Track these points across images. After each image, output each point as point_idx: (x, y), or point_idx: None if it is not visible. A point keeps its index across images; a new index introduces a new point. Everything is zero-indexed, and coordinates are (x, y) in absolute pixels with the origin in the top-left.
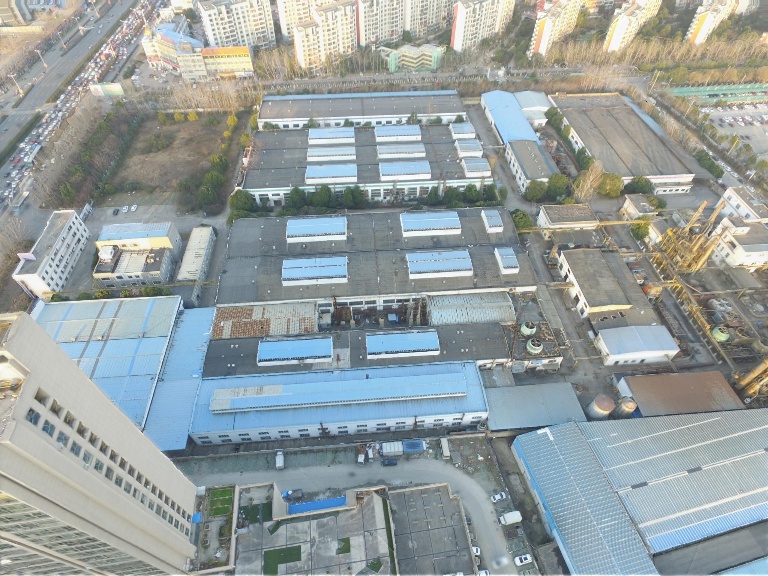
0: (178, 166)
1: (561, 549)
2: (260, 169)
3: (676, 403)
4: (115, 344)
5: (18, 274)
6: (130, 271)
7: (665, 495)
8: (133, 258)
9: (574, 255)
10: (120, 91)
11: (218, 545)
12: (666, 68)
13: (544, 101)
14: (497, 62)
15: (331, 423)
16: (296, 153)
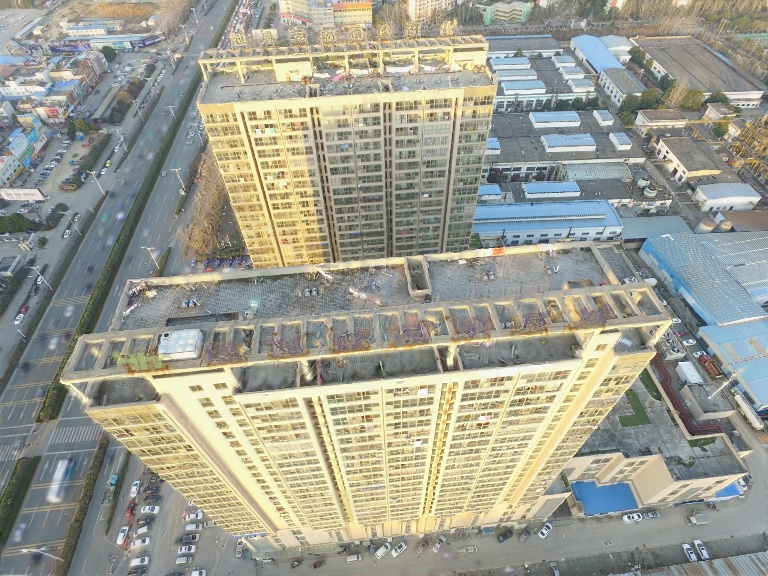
0: None
1: (687, 298)
2: None
3: (762, 225)
4: None
5: None
6: None
7: (759, 270)
8: None
9: (671, 141)
10: (275, 35)
11: None
12: (730, 18)
13: (626, 43)
14: (577, 16)
15: (511, 231)
16: None
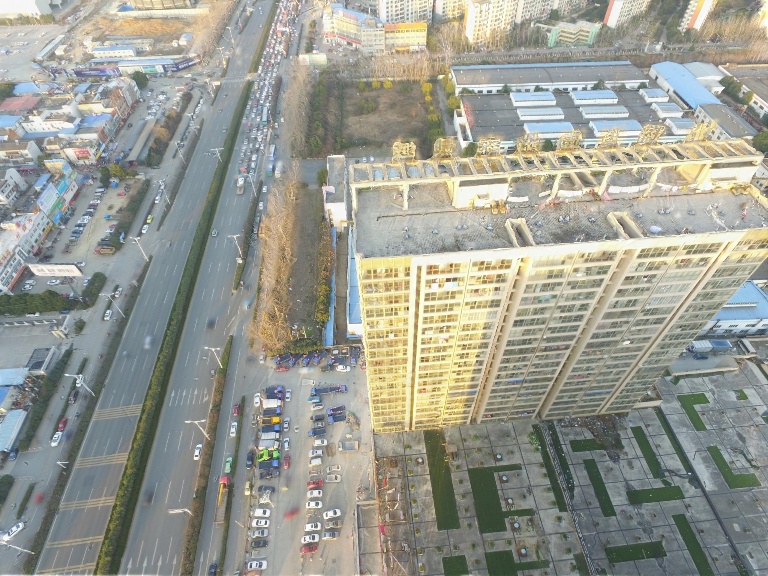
0: (392, 126)
1: None
2: (480, 126)
3: None
4: None
5: (329, 203)
6: None
7: None
8: None
9: None
10: (324, 61)
11: None
12: None
13: (715, 71)
14: None
15: None
16: (506, 113)
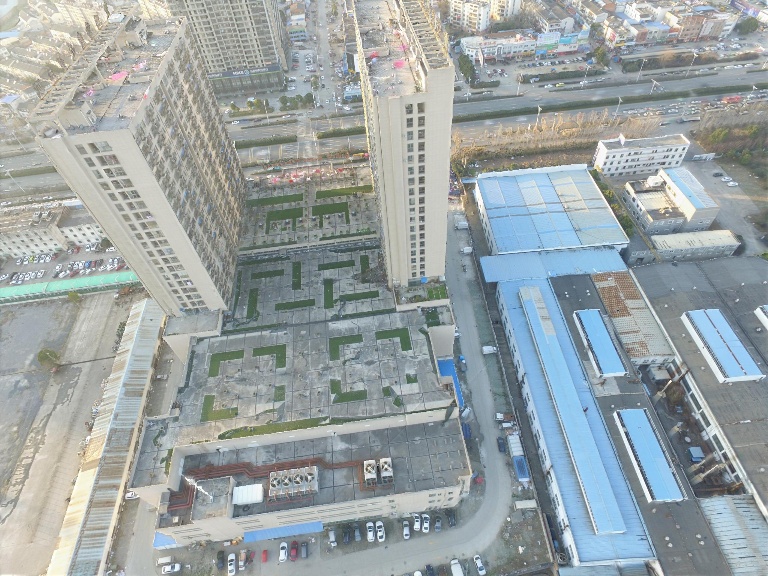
0: None
1: None
2: None
3: None
4: (563, 217)
5: (603, 142)
6: (643, 202)
7: None
8: (660, 199)
9: None
10: None
11: (409, 297)
12: None
13: None
14: None
15: (528, 383)
16: None
